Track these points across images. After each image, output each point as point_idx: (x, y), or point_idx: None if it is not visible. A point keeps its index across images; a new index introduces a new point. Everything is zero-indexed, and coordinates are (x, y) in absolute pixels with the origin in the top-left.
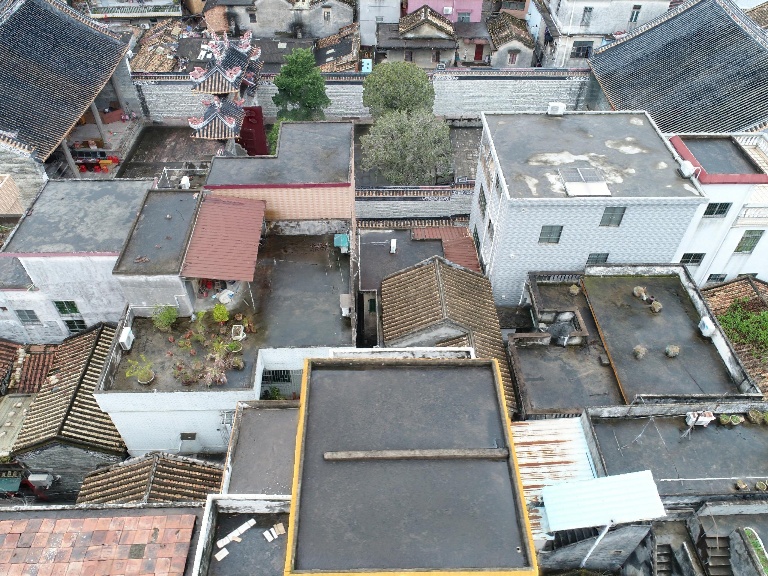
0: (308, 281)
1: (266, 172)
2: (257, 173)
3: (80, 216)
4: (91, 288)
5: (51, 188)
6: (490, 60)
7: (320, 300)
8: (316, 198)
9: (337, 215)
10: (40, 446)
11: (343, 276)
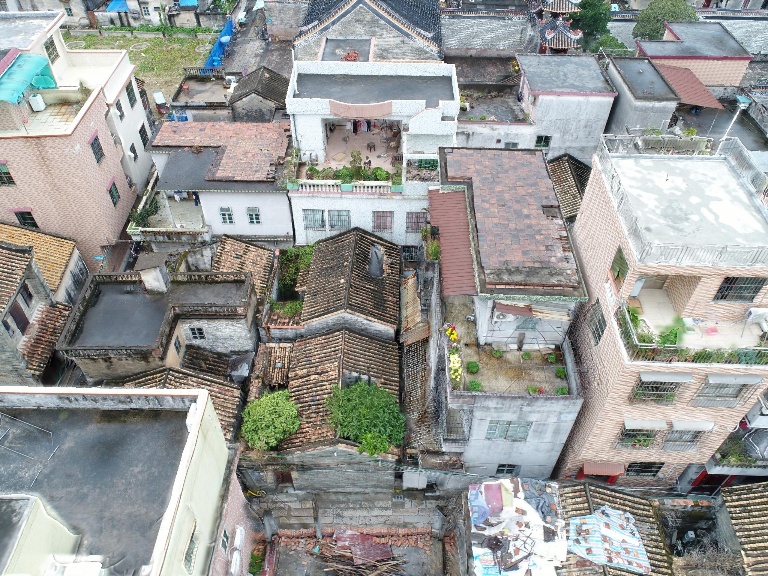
0: (728, 124)
1: (685, 49)
2: (679, 50)
3: (562, 74)
4: (572, 125)
5: (524, 59)
6: (722, 6)
7: (745, 134)
8: (721, 69)
9: (729, 84)
10: (574, 218)
11: (750, 122)
